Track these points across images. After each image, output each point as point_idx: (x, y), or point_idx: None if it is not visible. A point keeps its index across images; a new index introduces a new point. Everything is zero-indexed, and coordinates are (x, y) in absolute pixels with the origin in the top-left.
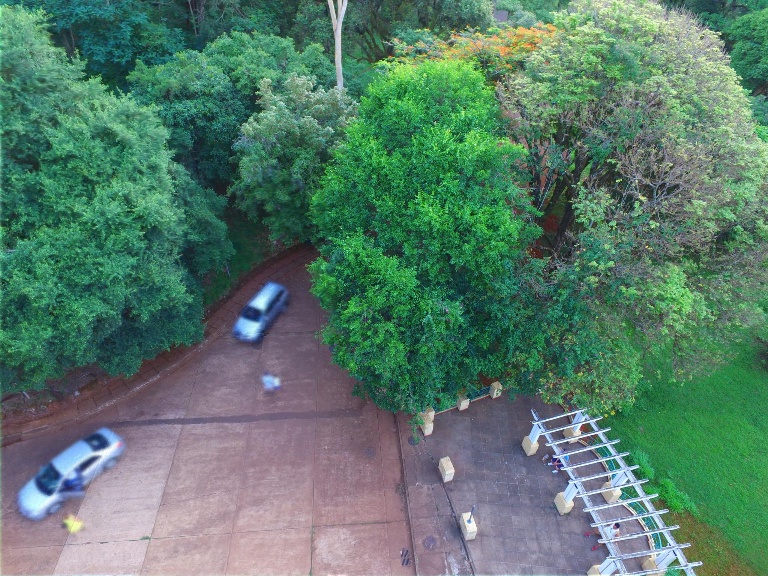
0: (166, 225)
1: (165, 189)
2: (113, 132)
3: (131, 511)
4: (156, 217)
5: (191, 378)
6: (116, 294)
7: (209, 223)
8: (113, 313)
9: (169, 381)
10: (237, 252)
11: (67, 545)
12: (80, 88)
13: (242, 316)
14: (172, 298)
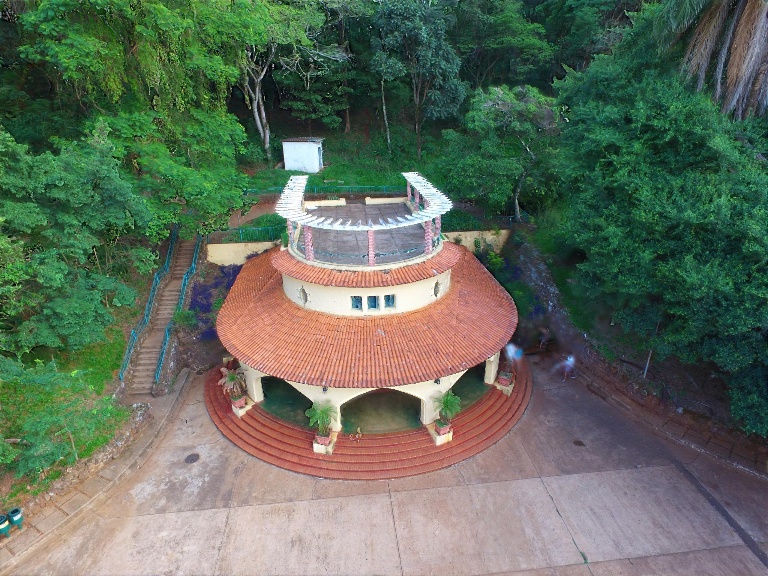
0: None
1: None
2: None
3: (603, 526)
4: None
5: None
6: None
7: None
8: None
9: None
10: None
11: (541, 479)
12: None
13: None
14: None
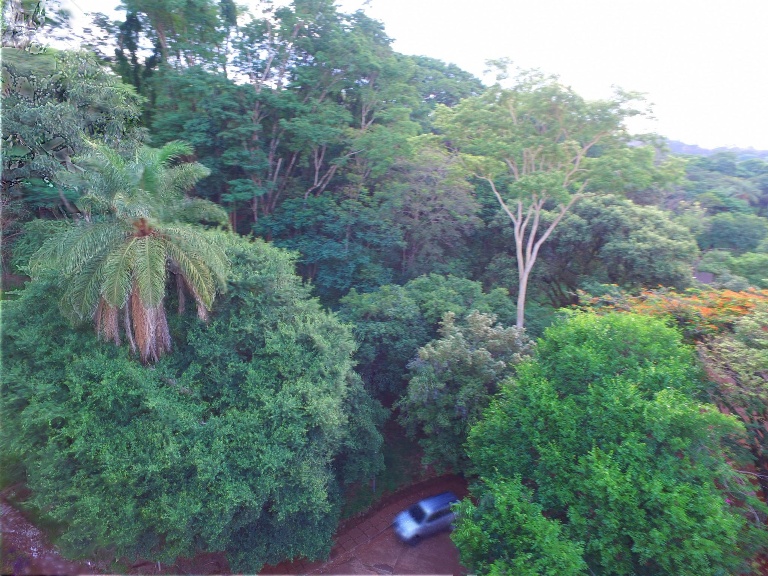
0: (328, 427)
1: (338, 394)
2: (312, 340)
3: None
4: (322, 418)
5: None
6: (264, 485)
7: (368, 433)
8: (255, 504)
9: None
10: (388, 468)
11: None
12: (301, 305)
13: (375, 543)
14: (312, 503)
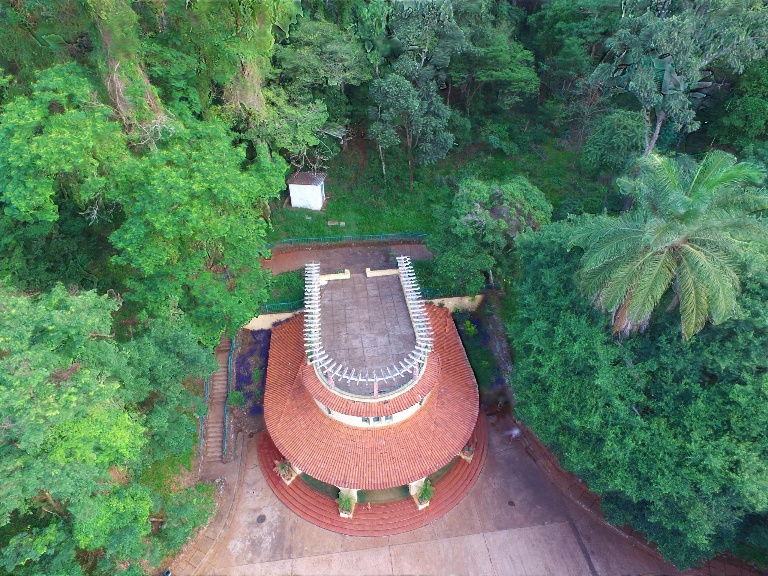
0: (749, 501)
1: None
2: None
3: (515, 570)
4: (746, 491)
5: (641, 570)
6: (650, 494)
7: None
8: (634, 499)
9: (628, 549)
10: None
11: (483, 535)
12: None
13: None
14: None
